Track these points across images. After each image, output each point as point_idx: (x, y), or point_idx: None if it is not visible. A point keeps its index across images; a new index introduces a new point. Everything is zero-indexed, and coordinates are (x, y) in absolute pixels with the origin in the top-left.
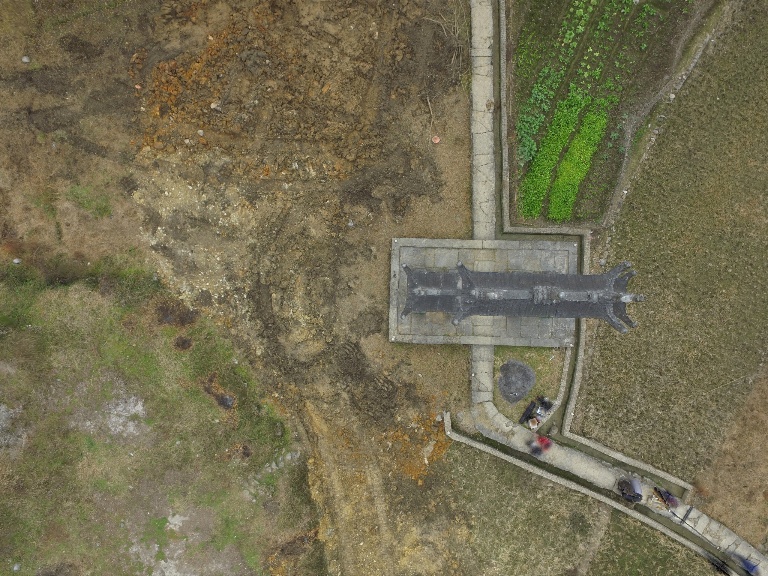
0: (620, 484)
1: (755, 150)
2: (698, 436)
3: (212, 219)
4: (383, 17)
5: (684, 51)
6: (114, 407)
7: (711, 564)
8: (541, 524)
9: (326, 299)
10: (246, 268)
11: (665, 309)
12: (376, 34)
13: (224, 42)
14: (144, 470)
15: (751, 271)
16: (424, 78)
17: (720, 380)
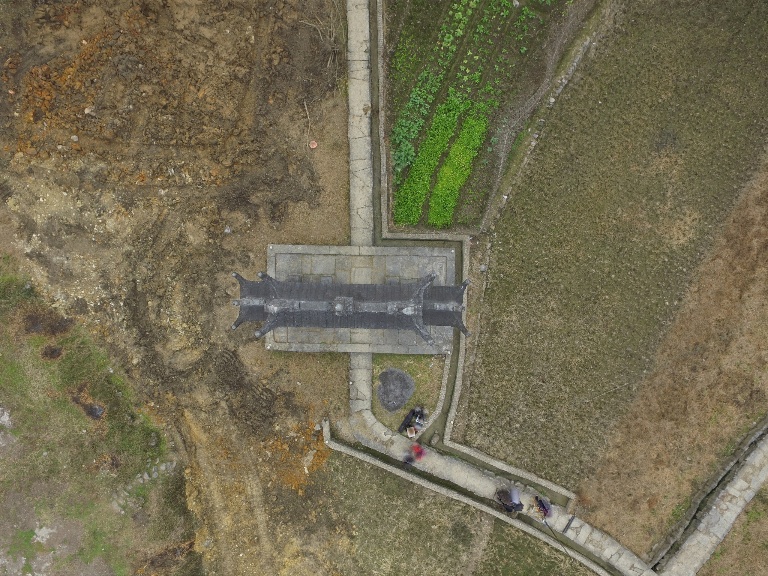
0: (499, 493)
1: (637, 154)
2: (582, 444)
3: (88, 226)
4: (260, 21)
5: (564, 54)
6: None
7: (595, 574)
8: (423, 534)
9: (204, 307)
10: (122, 275)
11: (548, 315)
12: (252, 38)
13: (97, 46)
14: (11, 482)
15: (634, 277)
16: (300, 82)
17: (604, 387)
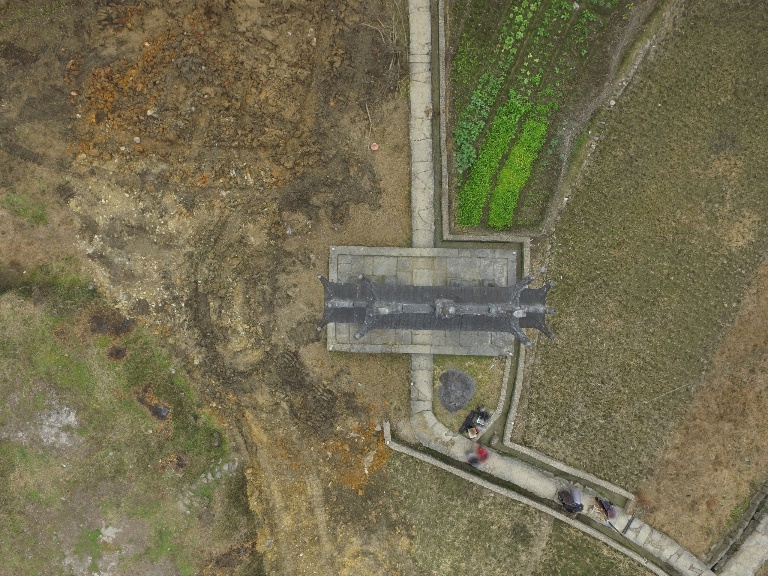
0: (560, 494)
1: (697, 157)
2: (640, 445)
3: (149, 227)
4: (321, 23)
5: (624, 57)
6: (46, 418)
7: (654, 574)
8: (482, 534)
9: (265, 308)
10: (183, 276)
11: (607, 317)
12: (314, 40)
13: (160, 48)
14: (77, 482)
15: (693, 278)
16: (362, 84)
17: (662, 388)
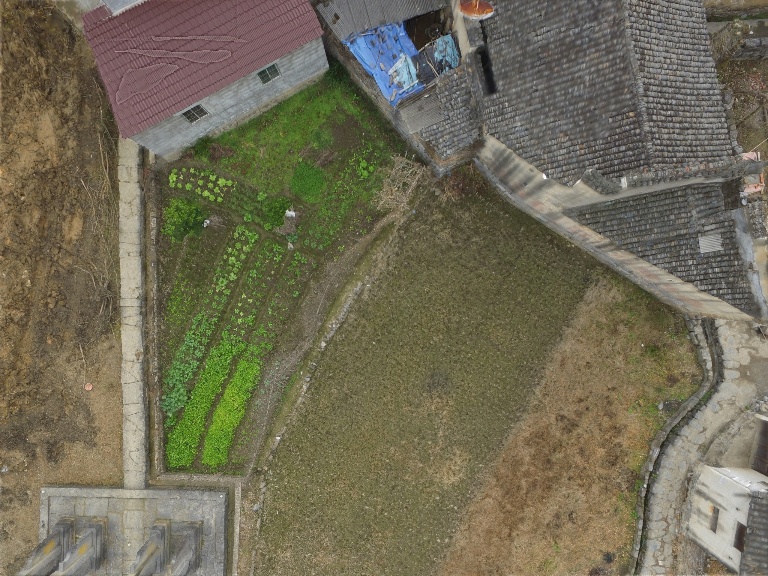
0: None
1: (409, 395)
2: None
3: None
4: (38, 263)
5: (335, 299)
6: None
7: None
8: None
9: None
10: None
11: (322, 552)
12: (28, 282)
13: None
14: None
15: (407, 514)
16: (75, 327)
17: None
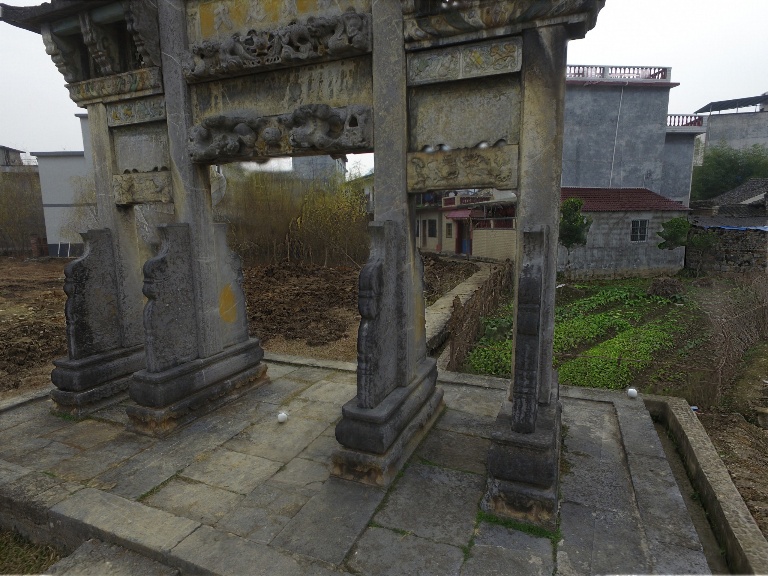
0: None
1: None
2: None
3: None
4: None
5: None
6: None
7: None
8: None
9: None
10: None
11: None
12: (349, 288)
13: None
14: None
15: None
16: None
17: None
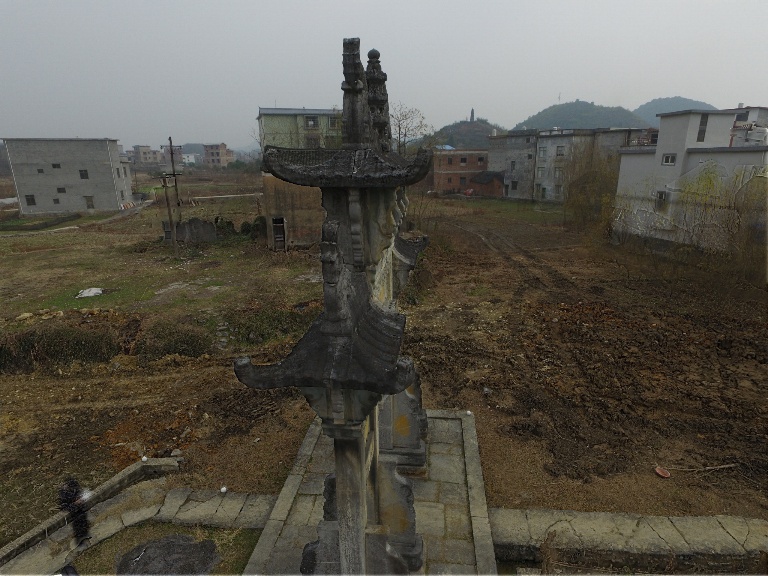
0: None
1: None
2: None
3: None
4: None
5: None
6: None
7: None
8: None
9: None
10: None
11: None
12: None
13: None
14: None
15: None
16: None
17: None
